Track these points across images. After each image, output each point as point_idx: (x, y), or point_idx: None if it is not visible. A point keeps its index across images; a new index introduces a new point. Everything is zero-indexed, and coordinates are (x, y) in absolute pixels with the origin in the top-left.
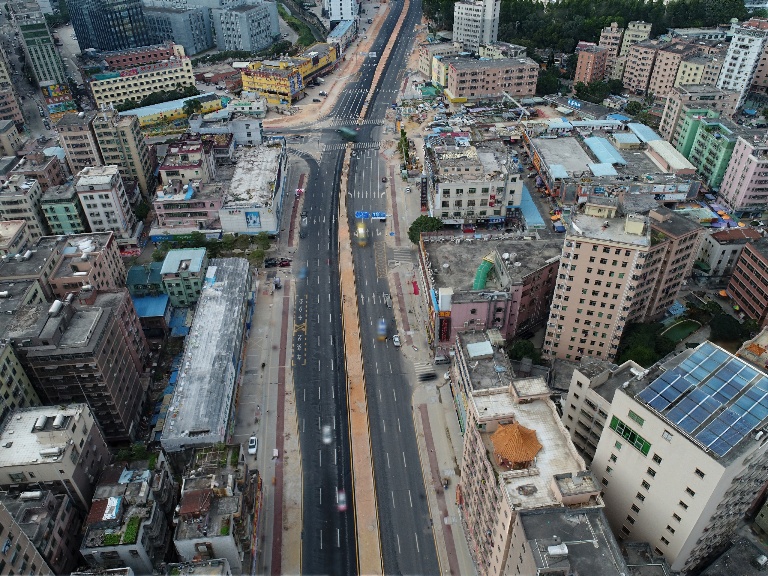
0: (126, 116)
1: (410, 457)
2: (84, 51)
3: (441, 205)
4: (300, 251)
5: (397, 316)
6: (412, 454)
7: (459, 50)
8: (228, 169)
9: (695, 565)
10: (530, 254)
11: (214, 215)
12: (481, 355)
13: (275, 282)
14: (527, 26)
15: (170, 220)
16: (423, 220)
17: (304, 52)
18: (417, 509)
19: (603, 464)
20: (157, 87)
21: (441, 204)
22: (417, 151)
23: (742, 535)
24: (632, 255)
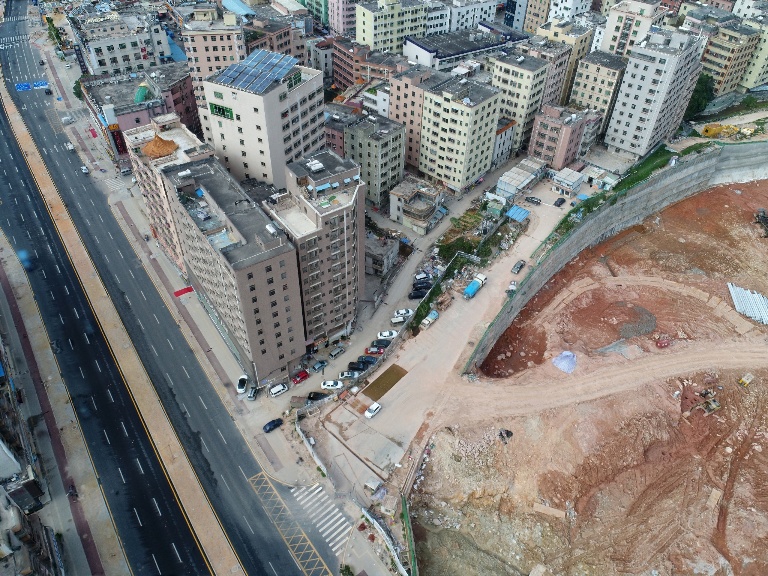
0: None
1: (115, 233)
2: None
3: (98, 64)
4: None
5: (81, 155)
6: (116, 231)
7: None
8: None
9: None
10: (174, 72)
11: None
12: None
13: None
14: None
15: None
16: None
17: None
18: (127, 258)
19: (220, 146)
20: None
21: (98, 63)
22: (69, 36)
23: None
24: (232, 39)
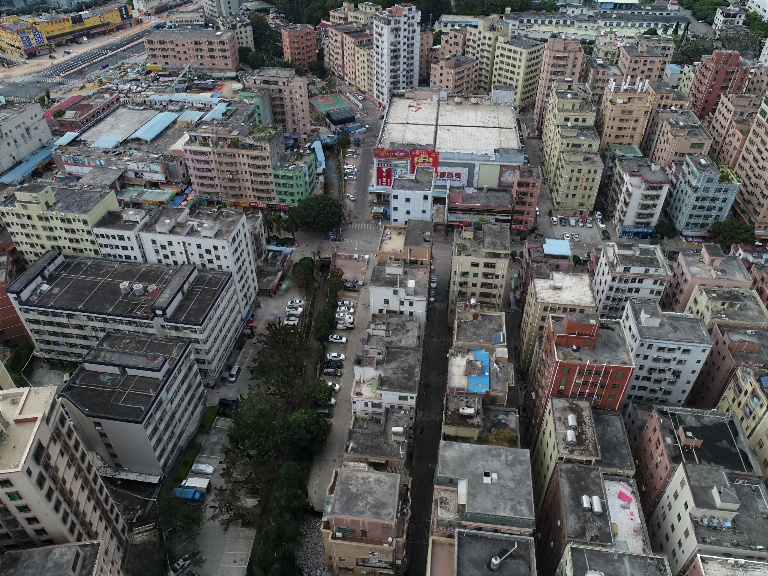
0: None
1: None
2: None
3: None
4: None
5: None
6: None
7: (200, 19)
8: None
9: None
10: None
11: None
12: None
13: None
14: (300, 1)
15: None
16: None
17: None
18: None
19: None
20: None
21: None
22: None
23: None
24: None
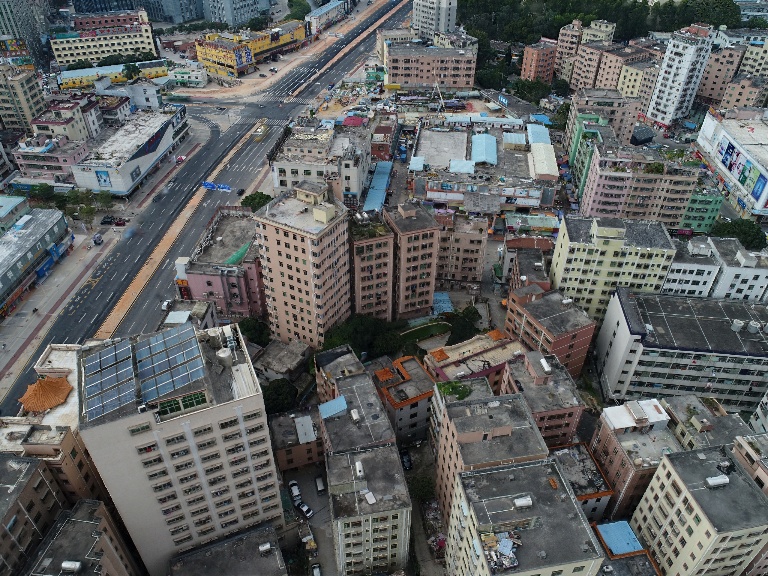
0: (25, 71)
1: None
2: (59, 11)
3: (279, 184)
4: (144, 213)
5: None
6: None
7: (414, 37)
8: (114, 130)
9: (209, 541)
10: None
11: (68, 170)
12: (174, 323)
13: (94, 238)
14: (499, 18)
15: (30, 171)
16: (253, 196)
17: (273, 28)
18: None
19: None
20: (116, 50)
21: (279, 183)
22: None
23: (322, 528)
24: (306, 242)
